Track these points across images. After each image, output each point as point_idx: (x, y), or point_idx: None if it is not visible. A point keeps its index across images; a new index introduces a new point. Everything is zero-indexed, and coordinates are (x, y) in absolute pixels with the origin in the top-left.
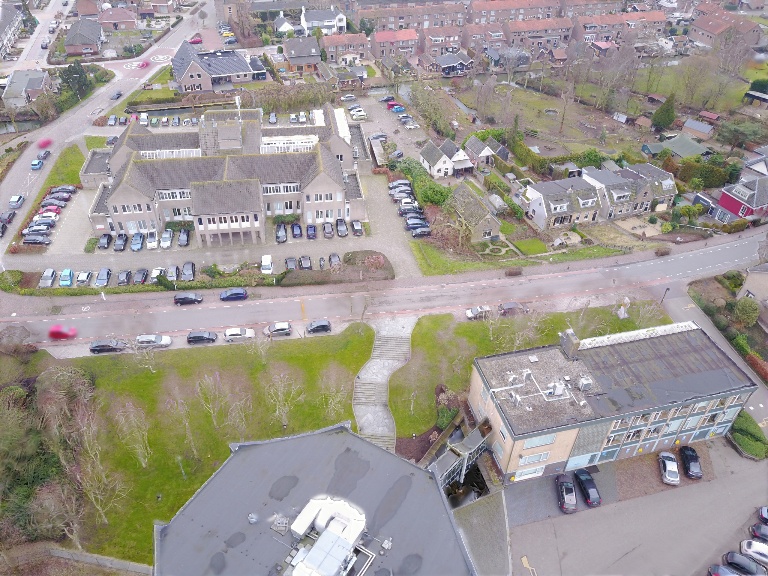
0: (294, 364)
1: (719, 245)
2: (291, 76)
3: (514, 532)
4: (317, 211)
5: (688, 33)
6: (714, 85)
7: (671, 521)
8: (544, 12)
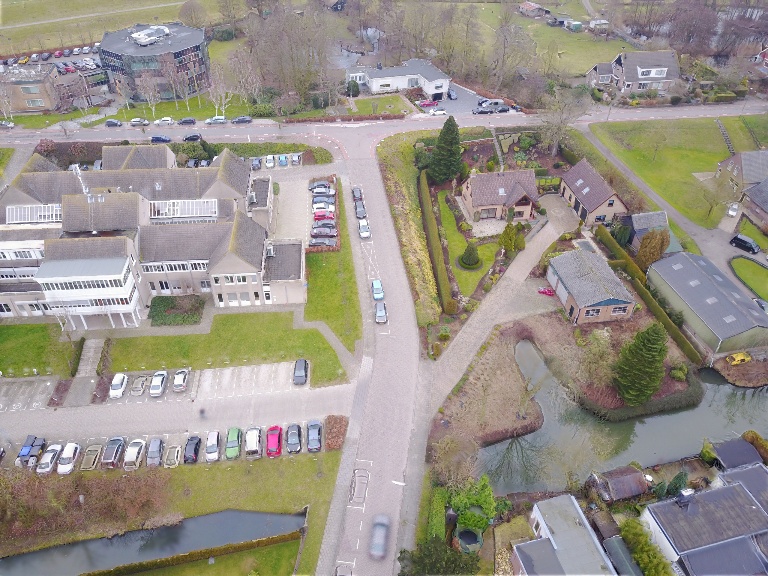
0: None
1: None
2: None
3: None
4: None
5: None
6: None
7: None
8: None
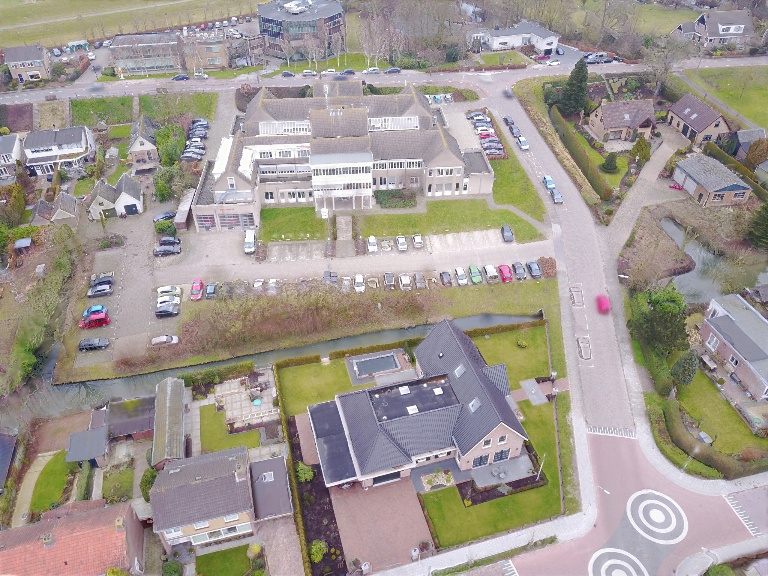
0: None
1: None
2: (253, 446)
3: None
4: None
5: None
6: None
7: None
8: None
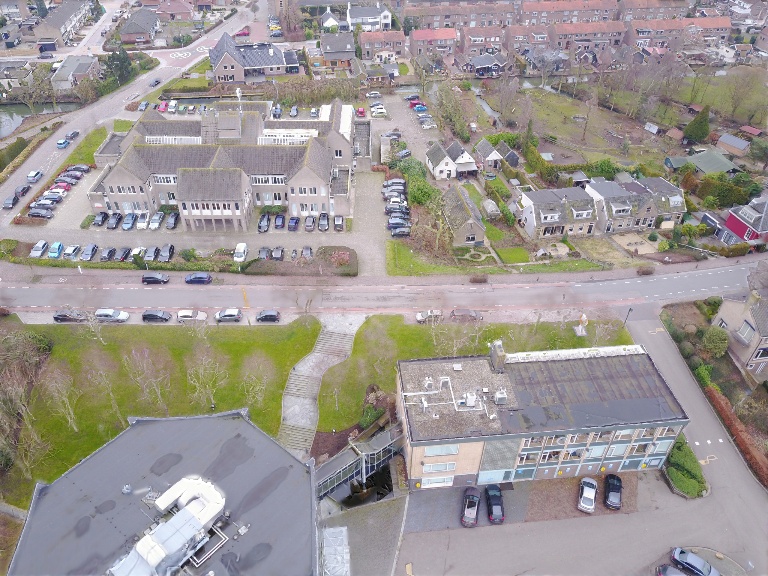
0: (236, 350)
1: (712, 269)
2: (324, 71)
3: (407, 538)
4: (302, 204)
5: (756, 41)
6: (763, 98)
7: (573, 549)
8: (600, 15)
